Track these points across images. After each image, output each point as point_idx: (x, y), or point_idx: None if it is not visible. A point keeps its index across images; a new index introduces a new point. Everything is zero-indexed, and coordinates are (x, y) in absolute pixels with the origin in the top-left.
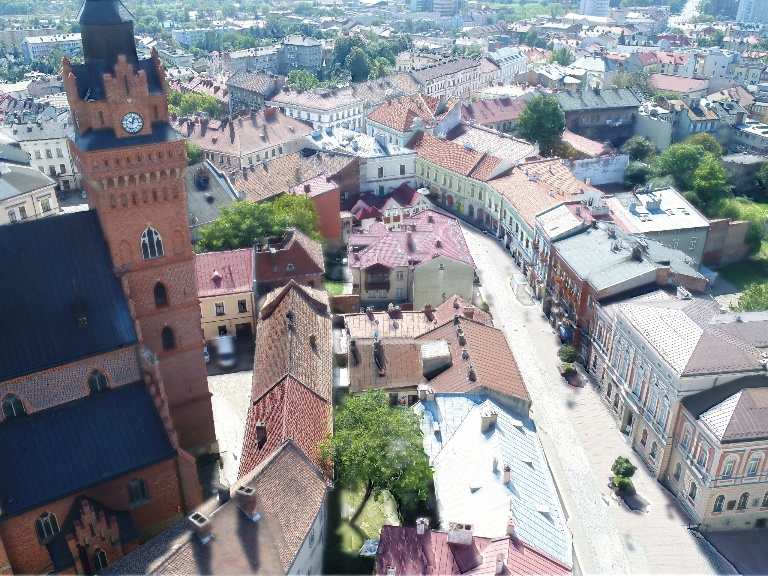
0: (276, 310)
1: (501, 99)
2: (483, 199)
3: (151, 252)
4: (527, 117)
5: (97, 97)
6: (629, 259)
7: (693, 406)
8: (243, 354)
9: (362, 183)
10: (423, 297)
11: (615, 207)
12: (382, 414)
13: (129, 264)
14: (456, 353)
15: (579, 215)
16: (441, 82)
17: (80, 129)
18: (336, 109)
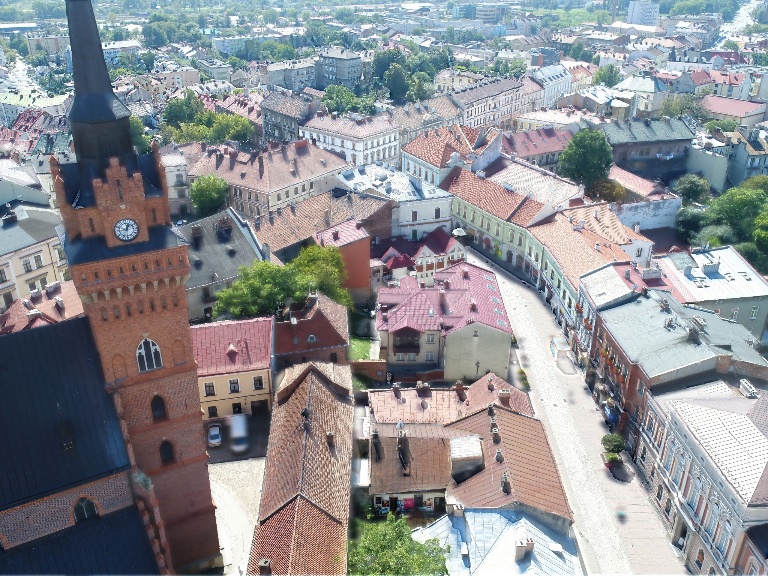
0: (293, 395)
1: (544, 129)
2: (523, 246)
3: (148, 364)
4: (572, 152)
5: (86, 203)
6: (685, 340)
7: (761, 540)
8: (258, 435)
9: (394, 227)
10: (455, 364)
11: (668, 270)
12: (402, 556)
13: (123, 378)
14: (489, 452)
15: (628, 279)
16: (481, 105)
17: (69, 235)
18: (371, 137)
